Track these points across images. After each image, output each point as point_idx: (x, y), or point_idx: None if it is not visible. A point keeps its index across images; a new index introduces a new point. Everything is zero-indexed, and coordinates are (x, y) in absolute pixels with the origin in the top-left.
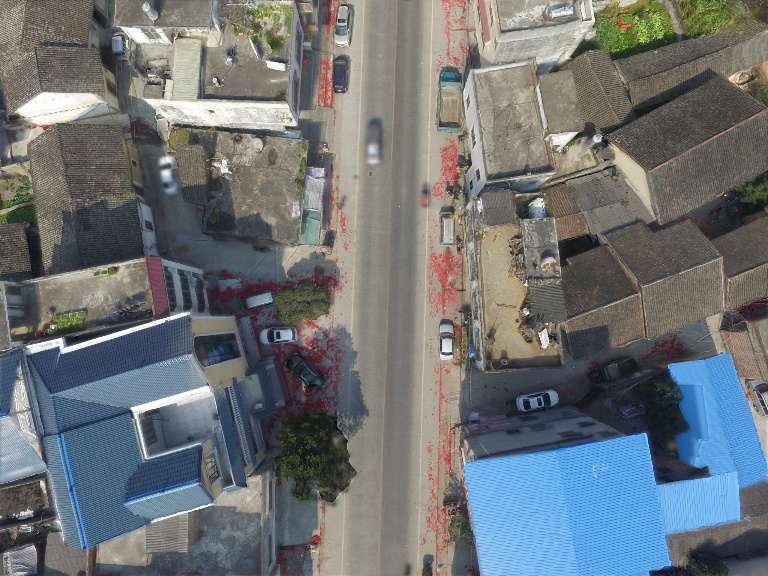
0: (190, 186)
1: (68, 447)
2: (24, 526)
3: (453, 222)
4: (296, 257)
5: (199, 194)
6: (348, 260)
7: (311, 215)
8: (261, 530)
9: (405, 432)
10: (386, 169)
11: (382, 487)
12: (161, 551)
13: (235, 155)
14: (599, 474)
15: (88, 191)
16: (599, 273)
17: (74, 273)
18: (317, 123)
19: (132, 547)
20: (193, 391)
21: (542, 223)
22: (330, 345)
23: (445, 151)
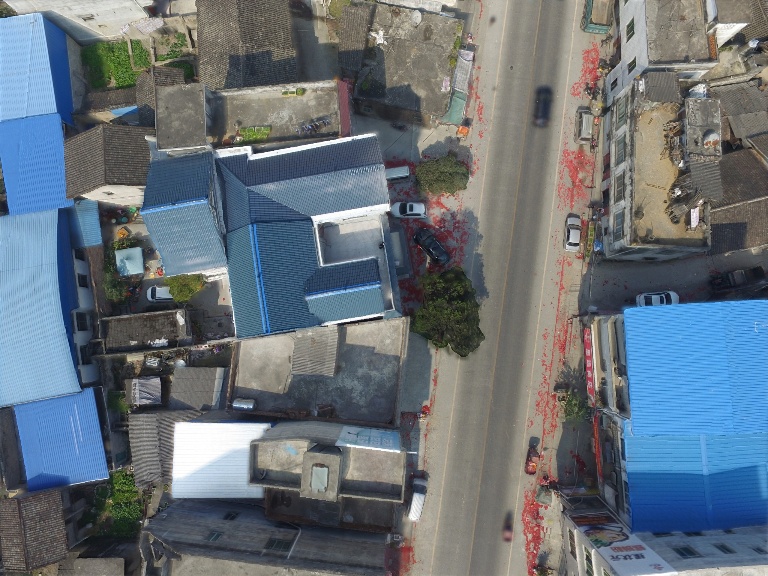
0: (348, 50)
1: (259, 237)
2: (151, 360)
3: (593, 118)
4: (431, 139)
5: (355, 59)
6: (482, 147)
7: (457, 95)
8: (400, 369)
9: (523, 317)
10: (527, 65)
11: (495, 367)
12: (307, 373)
13: (392, 27)
14: (760, 330)
15: (256, 39)
16: (743, 172)
17: (265, 89)
18: (464, 14)
19: (271, 374)
20: (373, 207)
21: (707, 103)
22: (457, 227)
23: (587, 53)
